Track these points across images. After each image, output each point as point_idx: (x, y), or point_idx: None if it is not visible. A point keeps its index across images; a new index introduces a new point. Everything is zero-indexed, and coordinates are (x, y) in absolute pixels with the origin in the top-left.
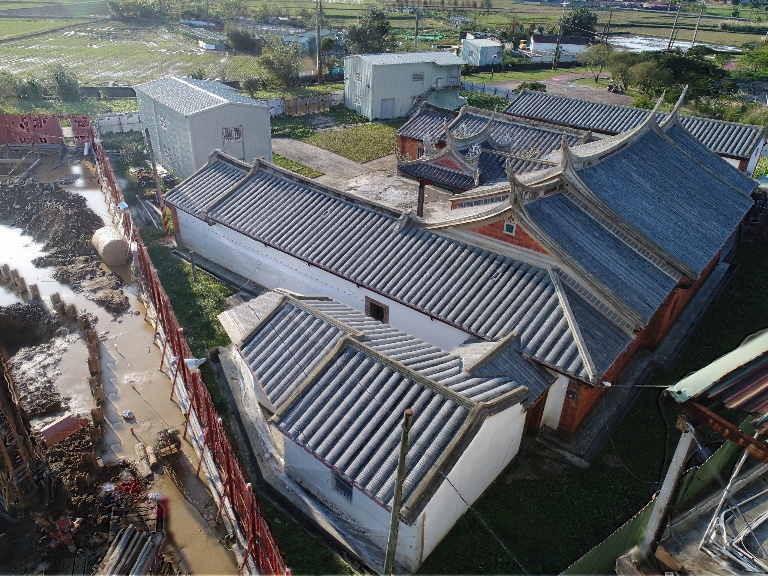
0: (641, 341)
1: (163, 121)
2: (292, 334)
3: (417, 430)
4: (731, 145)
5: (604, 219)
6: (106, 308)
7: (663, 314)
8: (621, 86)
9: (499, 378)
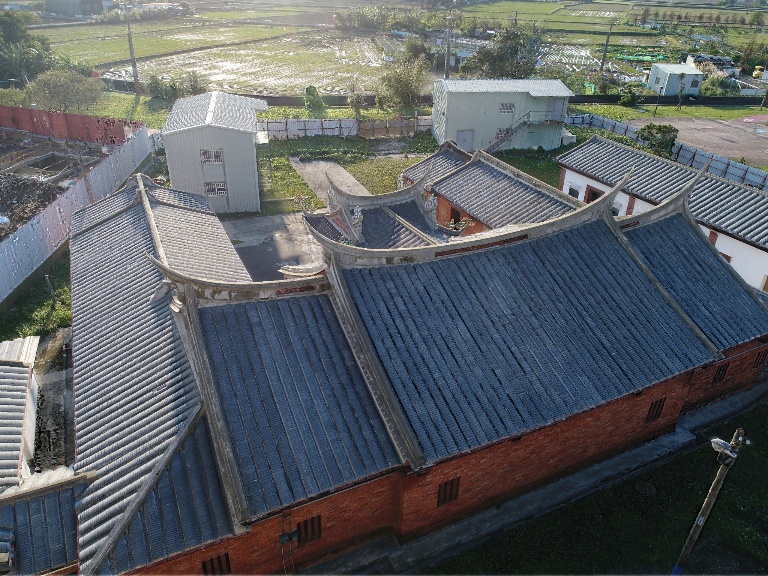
0: (384, 524)
1: None
2: None
3: None
4: None
5: None
6: None
7: (402, 498)
8: None
9: None
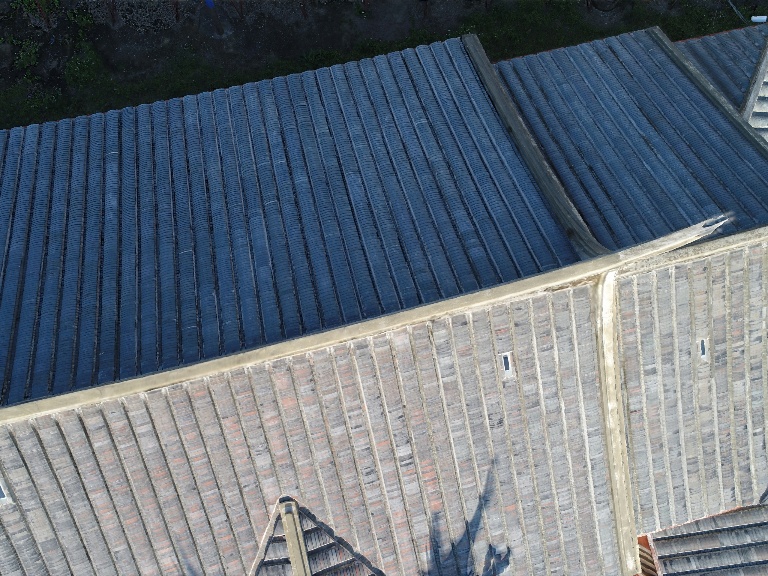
0: None
1: None
2: None
3: None
4: None
5: None
6: None
7: None
8: None
9: None
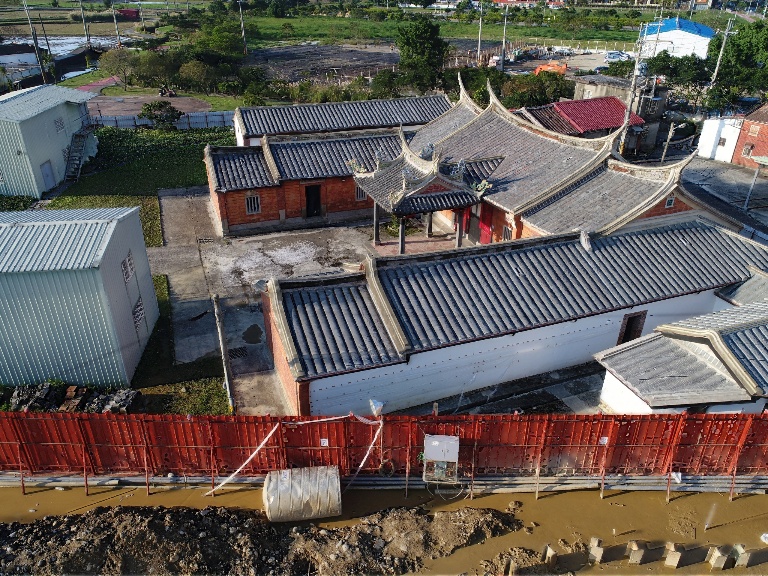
0: None
1: None
2: (764, 351)
3: None
4: None
5: None
6: (492, 534)
7: None
8: None
9: None
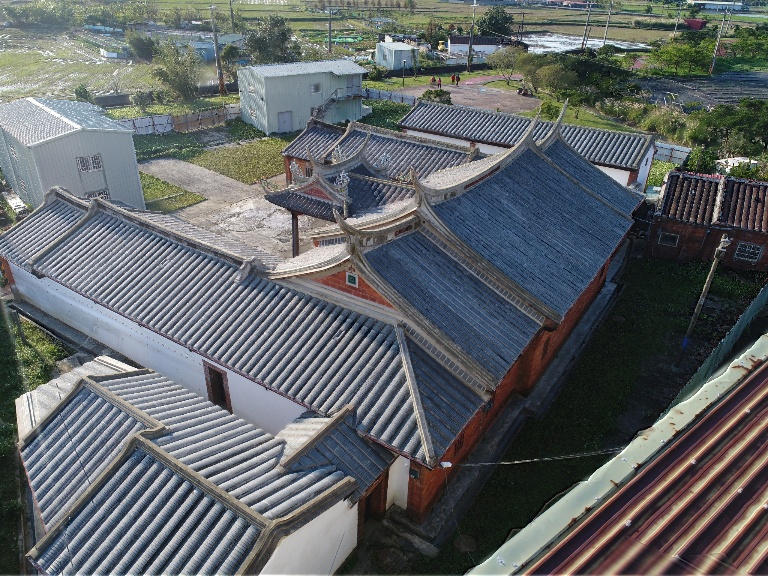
0: (512, 387)
1: (13, 150)
2: (83, 429)
3: (196, 562)
4: (620, 156)
5: (464, 258)
6: None
7: (532, 358)
8: (530, 89)
9: (321, 469)
